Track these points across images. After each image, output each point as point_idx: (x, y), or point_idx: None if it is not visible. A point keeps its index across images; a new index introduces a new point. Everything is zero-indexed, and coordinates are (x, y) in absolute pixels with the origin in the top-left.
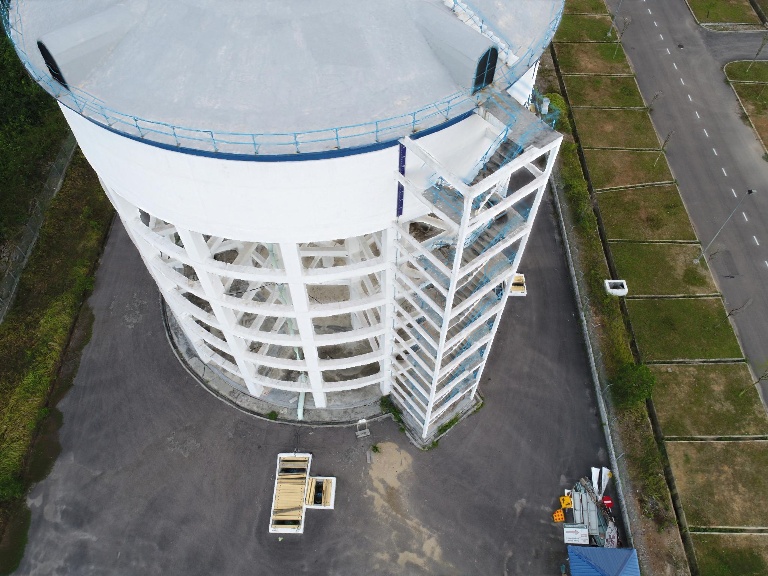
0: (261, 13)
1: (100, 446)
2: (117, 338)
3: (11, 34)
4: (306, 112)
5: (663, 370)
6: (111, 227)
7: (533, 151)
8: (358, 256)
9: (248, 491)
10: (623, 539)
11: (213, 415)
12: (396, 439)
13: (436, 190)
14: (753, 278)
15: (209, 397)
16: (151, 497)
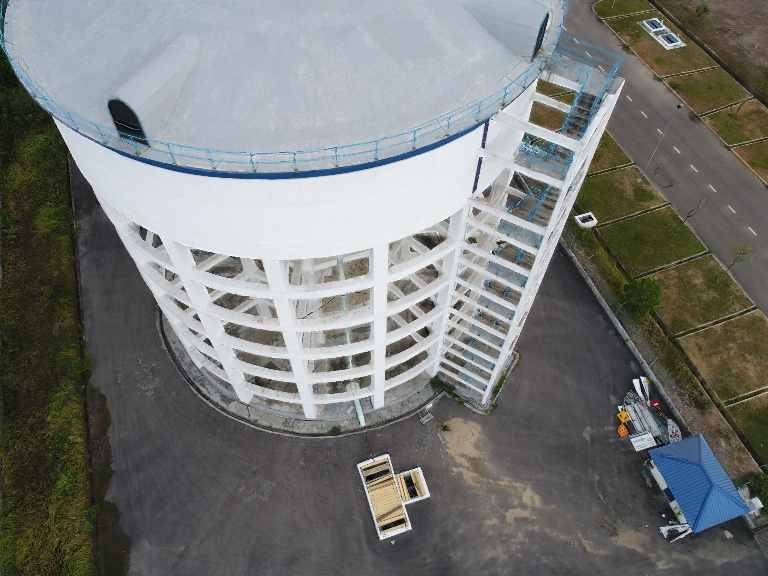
0: (323, 25)
1: (172, 522)
2: (140, 409)
3: (40, 103)
4: (404, 110)
5: (651, 280)
6: (81, 300)
7: (610, 98)
8: None
9: (343, 510)
10: None
11: (276, 451)
12: (458, 413)
13: (524, 156)
14: (687, 182)
15: (264, 435)
16: (248, 551)
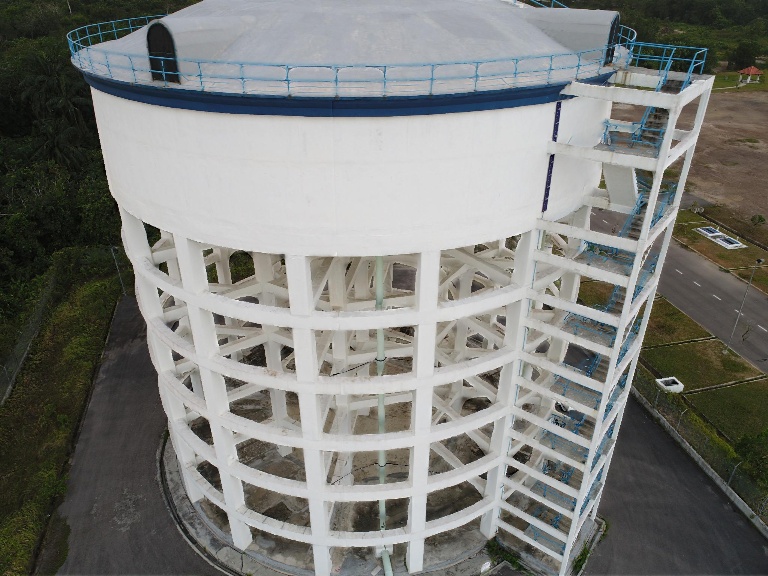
0: (383, 11)
1: None
2: (107, 548)
3: (84, 70)
4: (464, 68)
5: None
6: (82, 423)
7: (702, 81)
8: (437, 347)
9: None
10: None
11: None
12: None
13: (605, 145)
14: None
15: None
16: None
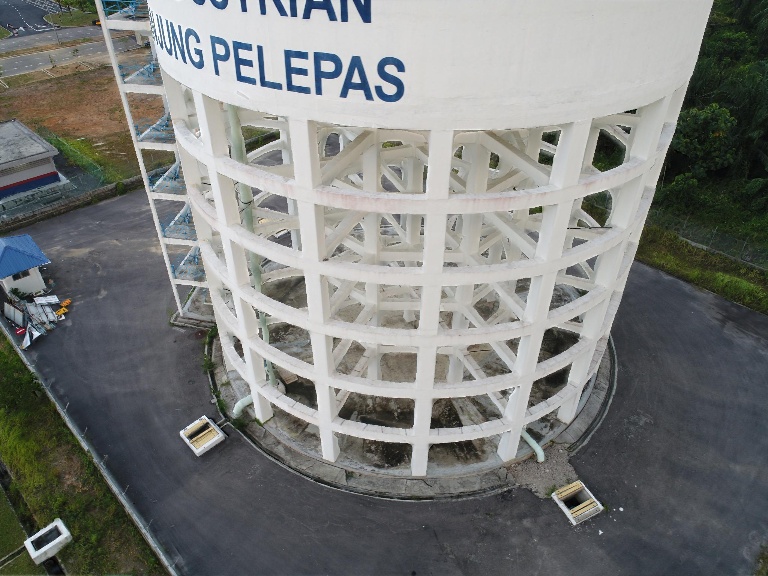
0: None
1: None
2: None
3: None
4: None
5: None
6: None
7: None
8: None
9: None
10: (2, 319)
11: None
12: None
13: None
14: None
15: None
16: None
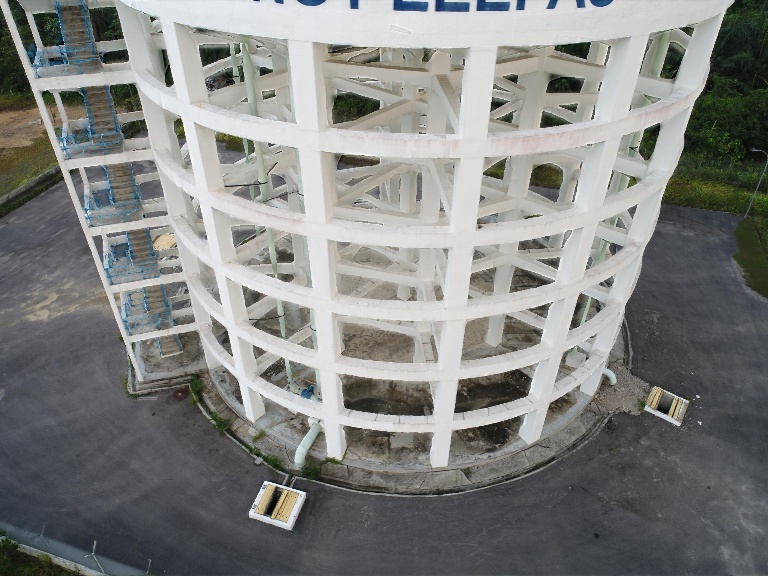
0: None
1: None
2: None
3: None
4: None
5: None
6: None
7: None
8: None
9: None
10: None
11: None
12: None
13: None
14: None
15: None
16: None
